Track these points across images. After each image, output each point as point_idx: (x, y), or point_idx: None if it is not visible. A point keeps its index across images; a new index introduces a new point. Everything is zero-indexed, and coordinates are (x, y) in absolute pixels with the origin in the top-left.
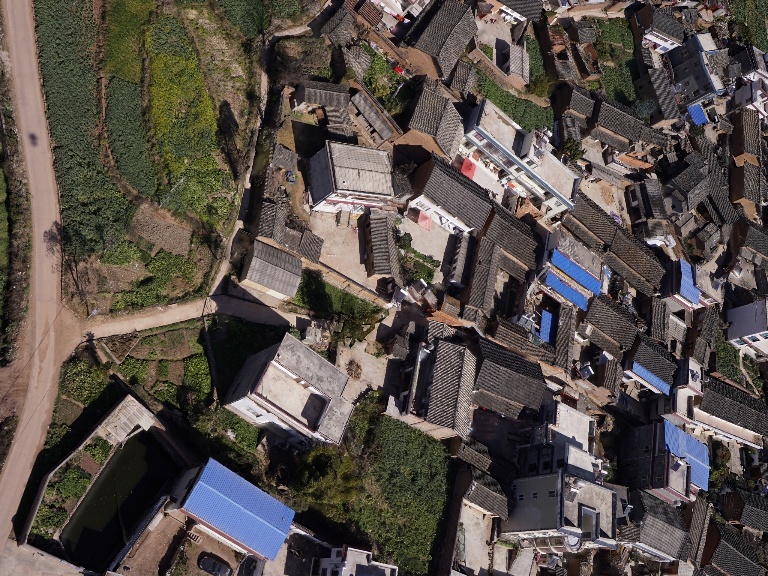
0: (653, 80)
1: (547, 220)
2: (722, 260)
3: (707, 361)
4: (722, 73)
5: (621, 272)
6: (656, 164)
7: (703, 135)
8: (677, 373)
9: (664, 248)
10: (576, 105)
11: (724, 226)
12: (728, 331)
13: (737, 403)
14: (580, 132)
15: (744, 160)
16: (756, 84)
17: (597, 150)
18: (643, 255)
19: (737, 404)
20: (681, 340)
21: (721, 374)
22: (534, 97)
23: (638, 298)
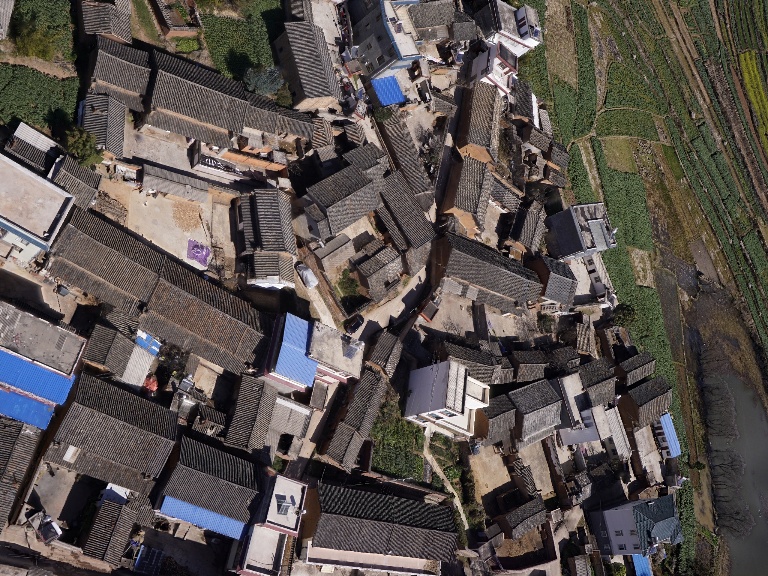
0: (292, 39)
1: (28, 265)
2: (414, 297)
3: (353, 458)
4: (446, 34)
5: (179, 341)
6: (294, 164)
7: (396, 119)
8: (258, 501)
9: (299, 289)
10: (109, 75)
11: (412, 250)
12: (406, 403)
13: (386, 523)
14: (138, 117)
15: (471, 153)
16: (494, 50)
17: (177, 145)
18: (217, 313)
19: (386, 525)
20: (299, 435)
21: (377, 474)
22: (36, 61)
23: (228, 375)
